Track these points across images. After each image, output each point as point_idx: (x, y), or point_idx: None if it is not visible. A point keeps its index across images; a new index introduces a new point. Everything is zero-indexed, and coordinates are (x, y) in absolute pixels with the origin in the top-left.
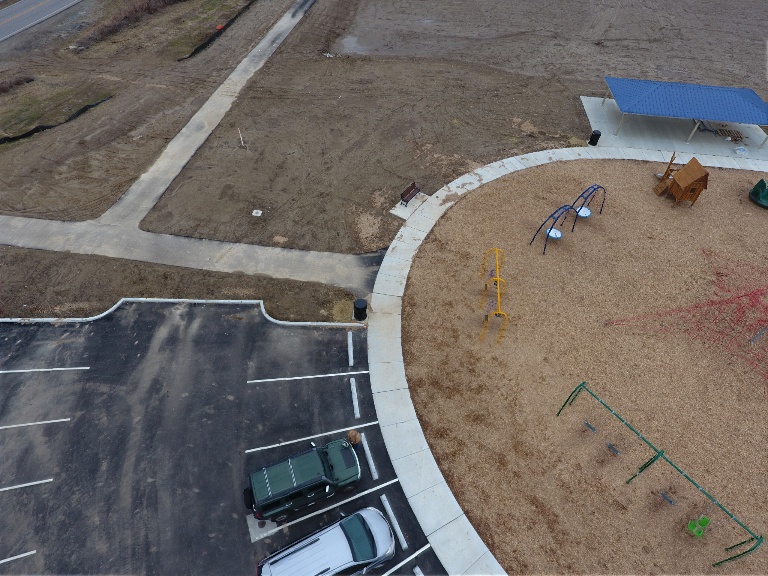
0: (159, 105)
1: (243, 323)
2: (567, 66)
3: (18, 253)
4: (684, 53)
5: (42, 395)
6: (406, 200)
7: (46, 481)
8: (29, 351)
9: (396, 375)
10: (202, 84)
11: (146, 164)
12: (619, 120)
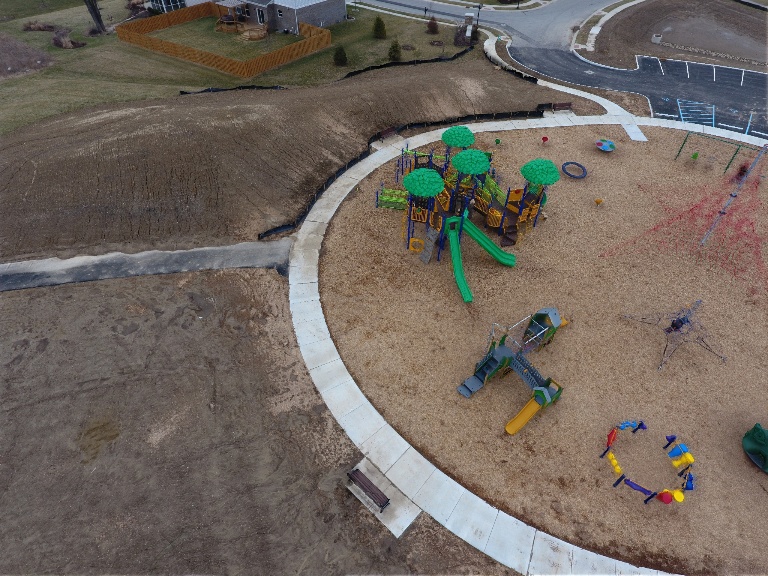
0: None
1: None
2: None
3: None
4: None
5: None
6: None
7: None
8: None
9: None
10: None
11: None
12: None
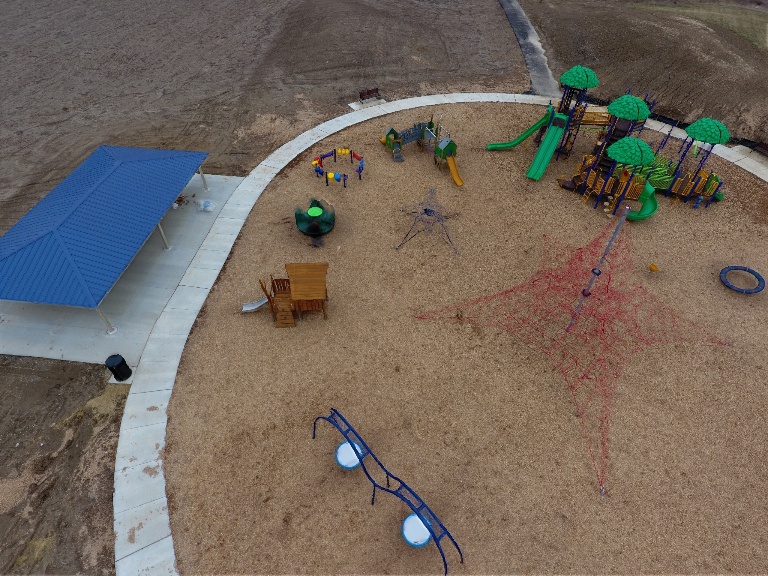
0: None
1: None
2: None
3: None
4: None
5: None
6: None
7: None
8: None
9: None
10: None
11: None
12: (64, 310)
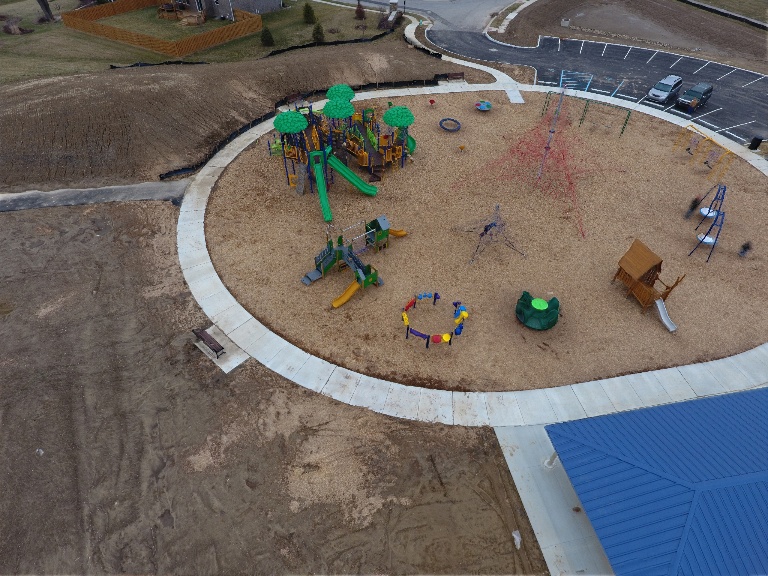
0: None
1: None
2: None
3: None
4: None
5: None
6: None
7: None
8: None
9: None
10: None
11: None
12: None
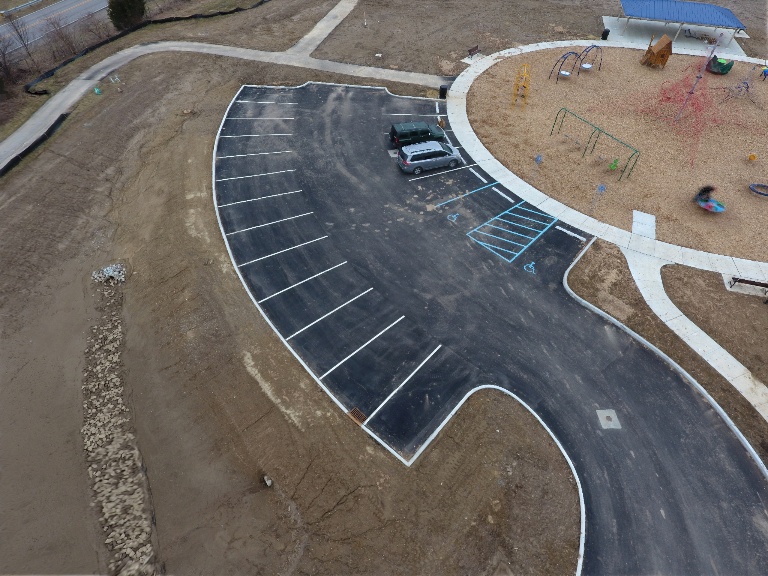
0: (306, 5)
1: (377, 95)
2: (598, 1)
3: (246, 61)
4: None
5: (277, 110)
6: (472, 54)
7: (289, 134)
8: (265, 96)
9: (462, 118)
10: None
11: (306, 31)
12: (627, 29)
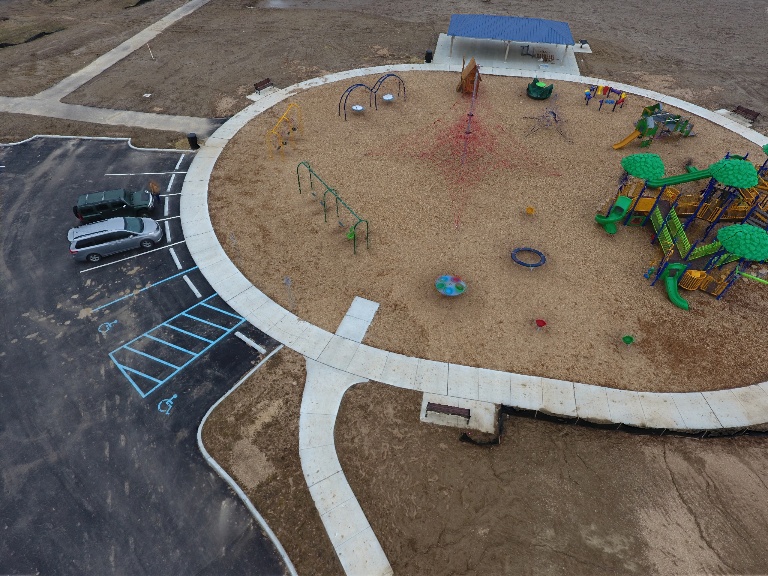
0: (99, 35)
1: (113, 149)
2: (447, 16)
3: None
4: (555, 8)
5: None
6: (259, 89)
7: None
8: None
9: (204, 174)
10: (138, 23)
11: (77, 68)
12: (460, 48)
